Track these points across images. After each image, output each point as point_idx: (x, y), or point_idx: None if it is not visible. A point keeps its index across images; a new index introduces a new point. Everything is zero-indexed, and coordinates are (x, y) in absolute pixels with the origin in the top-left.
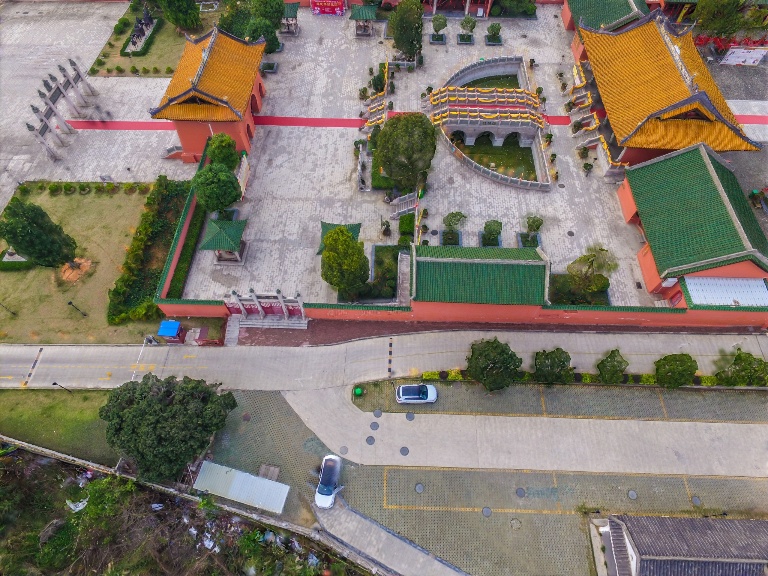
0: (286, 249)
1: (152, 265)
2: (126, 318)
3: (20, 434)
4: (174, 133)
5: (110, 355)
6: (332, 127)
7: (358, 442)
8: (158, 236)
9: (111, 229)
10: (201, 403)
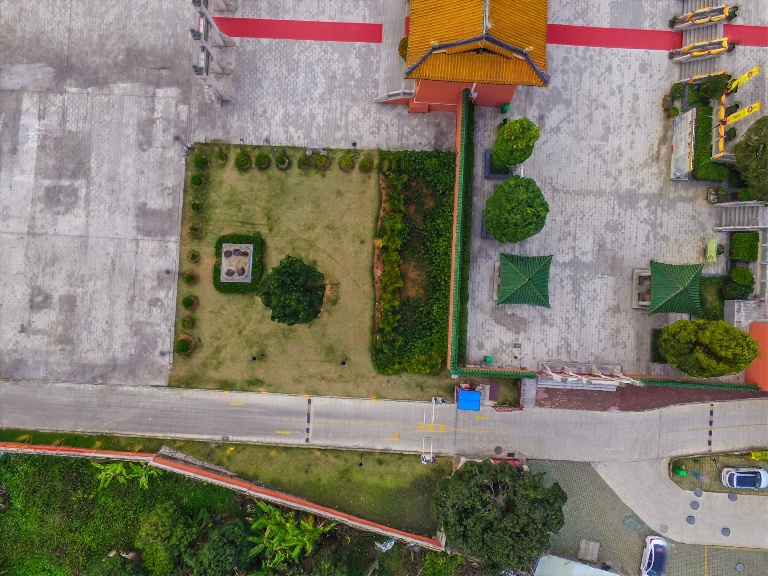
0: (580, 277)
1: (407, 290)
2: (400, 369)
3: (327, 500)
4: (382, 50)
5: (391, 411)
6: (627, 49)
7: (678, 521)
8: (408, 248)
9: (339, 231)
10: (540, 507)
